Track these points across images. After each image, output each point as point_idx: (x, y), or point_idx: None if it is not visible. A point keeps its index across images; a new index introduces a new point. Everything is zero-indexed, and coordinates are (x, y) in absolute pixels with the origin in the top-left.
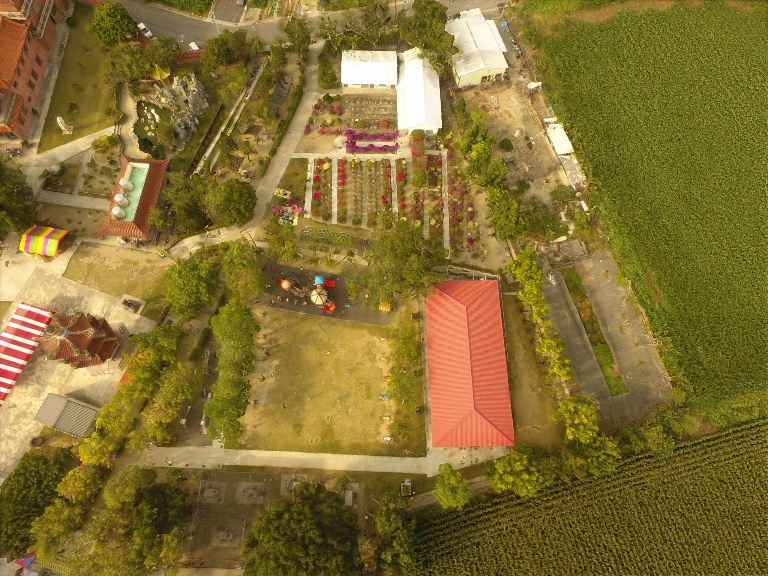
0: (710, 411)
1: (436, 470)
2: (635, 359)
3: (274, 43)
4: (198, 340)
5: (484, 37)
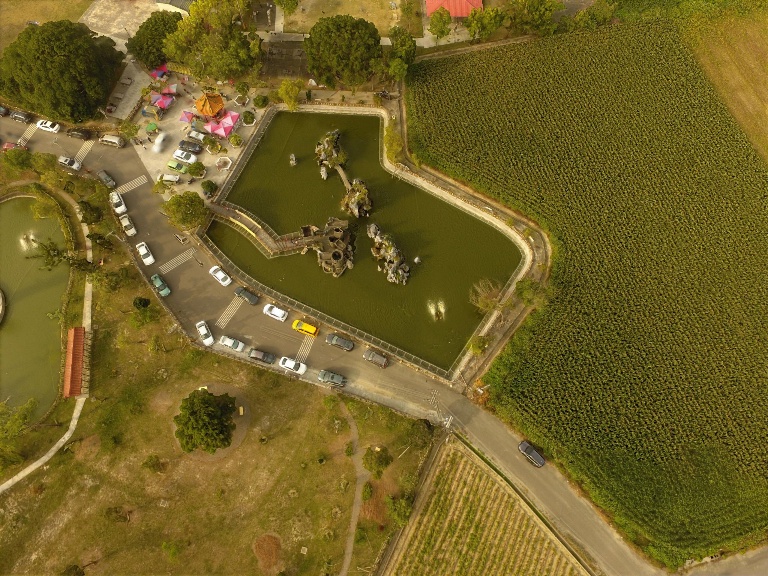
0: (625, 15)
1: (430, 45)
2: None
3: None
4: None
5: None
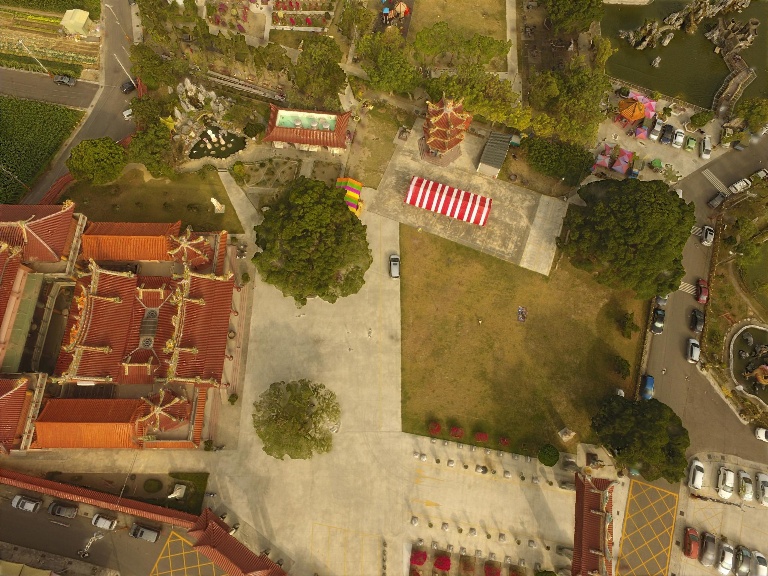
0: None
1: None
2: None
3: None
4: None
5: None
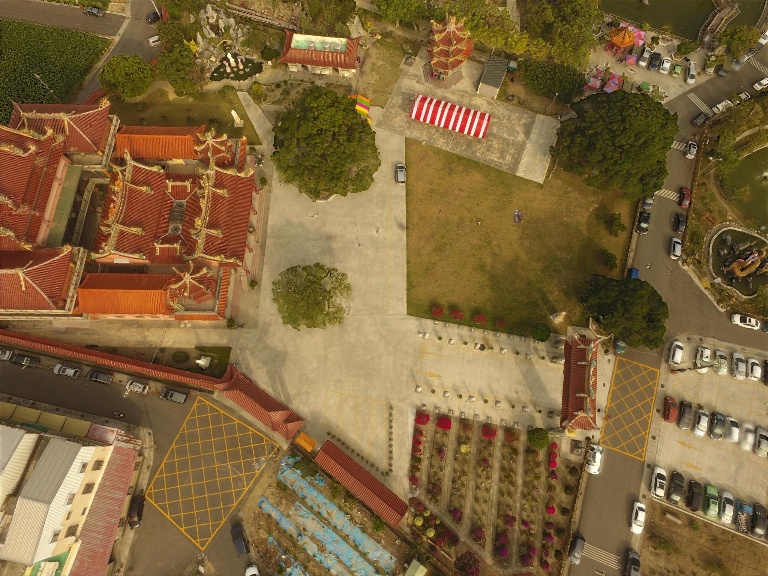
0: None
1: None
2: None
3: None
4: None
5: None
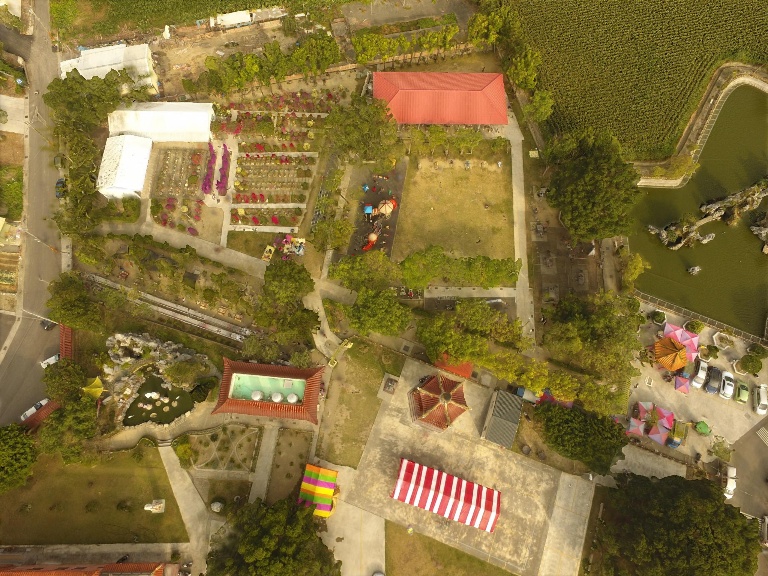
0: None
1: (519, 134)
2: (430, 4)
3: (59, 273)
4: (424, 318)
5: (106, 58)
